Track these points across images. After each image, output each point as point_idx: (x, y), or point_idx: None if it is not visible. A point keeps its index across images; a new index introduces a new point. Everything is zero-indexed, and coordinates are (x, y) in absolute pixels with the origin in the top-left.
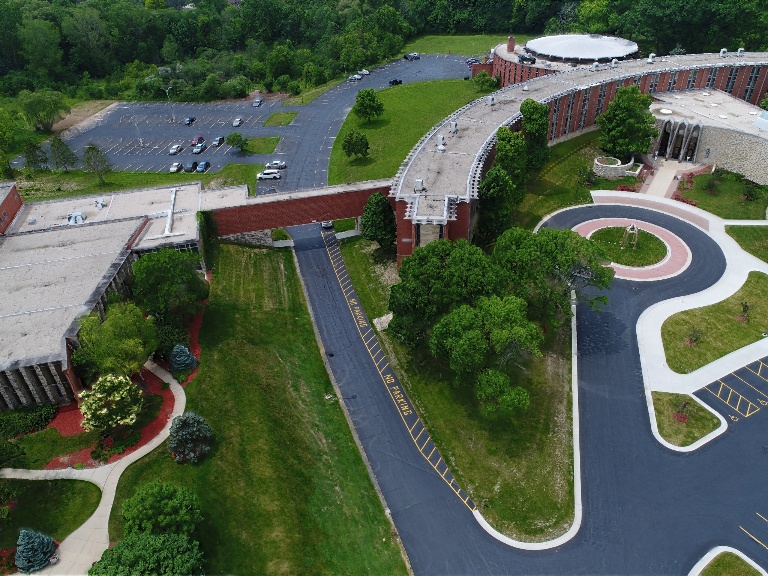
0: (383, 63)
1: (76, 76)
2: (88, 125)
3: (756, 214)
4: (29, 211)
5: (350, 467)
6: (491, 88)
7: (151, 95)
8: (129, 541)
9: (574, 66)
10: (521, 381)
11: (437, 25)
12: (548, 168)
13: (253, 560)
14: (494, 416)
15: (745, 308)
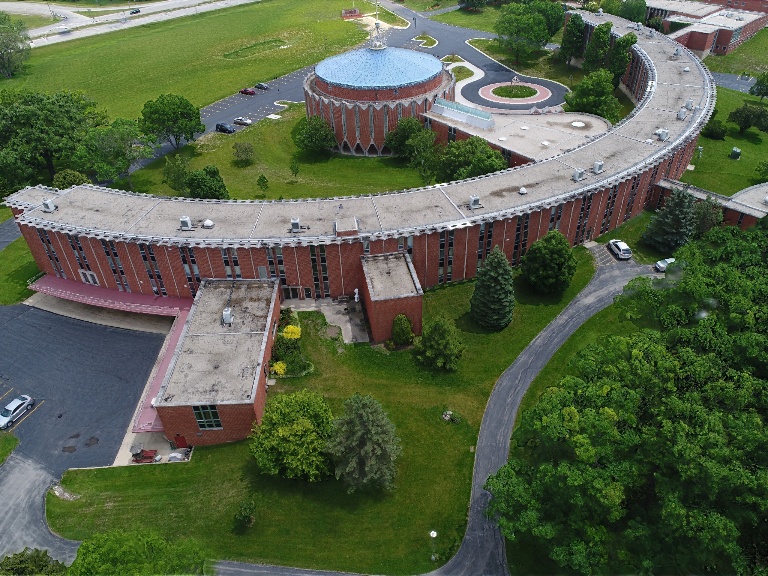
0: None
1: None
2: None
3: None
4: None
5: None
6: None
7: None
8: None
9: None
10: None
11: None
12: None
13: None
14: (505, 48)
15: None
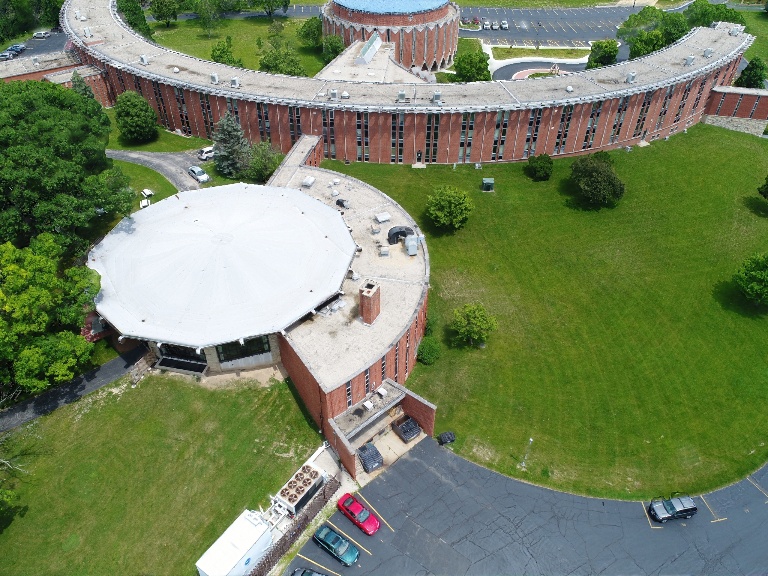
0: None
1: None
2: None
3: (440, 75)
4: None
5: None
6: (440, 345)
7: None
8: None
9: None
10: None
11: None
12: None
13: None
14: None
15: None
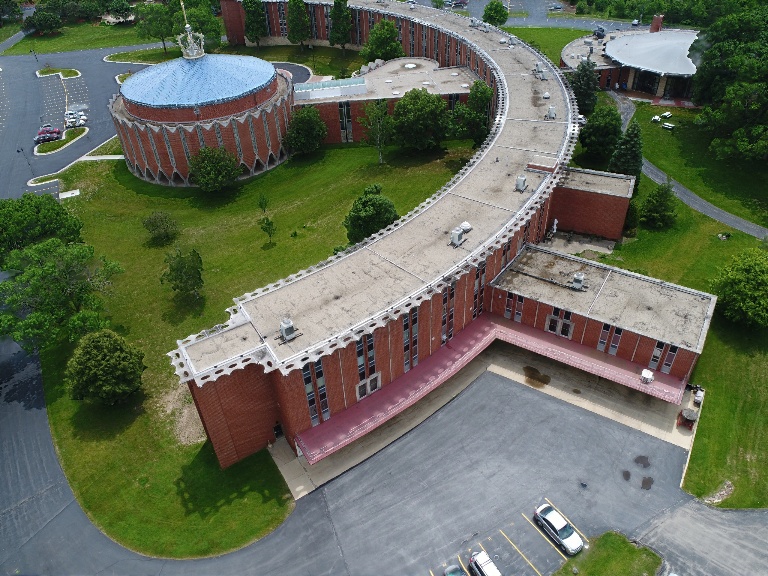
0: None
1: None
2: None
3: None
4: None
5: (157, 41)
6: None
7: None
8: (127, 2)
9: None
10: (172, 57)
11: None
12: None
13: (131, 30)
14: (159, 54)
15: None
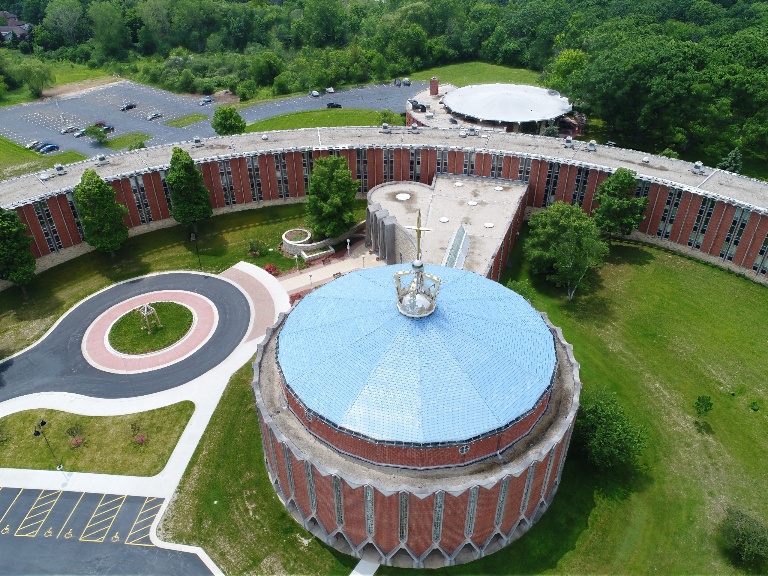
0: (370, 84)
1: (128, 53)
2: (75, 96)
3: None
4: None
5: None
6: None
7: (148, 79)
8: None
9: (454, 123)
10: None
11: (488, 52)
12: (245, 226)
13: None
14: None
15: None
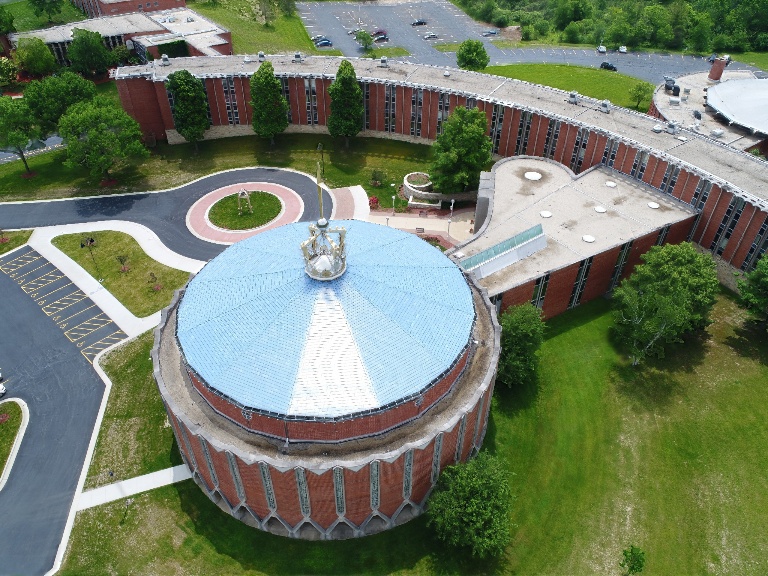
0: (679, 52)
1: None
2: (392, 4)
3: None
4: (180, 11)
5: None
6: None
7: (460, 1)
8: None
9: (697, 117)
10: (48, 182)
11: None
12: (390, 155)
13: None
14: (16, 177)
15: (119, 257)
